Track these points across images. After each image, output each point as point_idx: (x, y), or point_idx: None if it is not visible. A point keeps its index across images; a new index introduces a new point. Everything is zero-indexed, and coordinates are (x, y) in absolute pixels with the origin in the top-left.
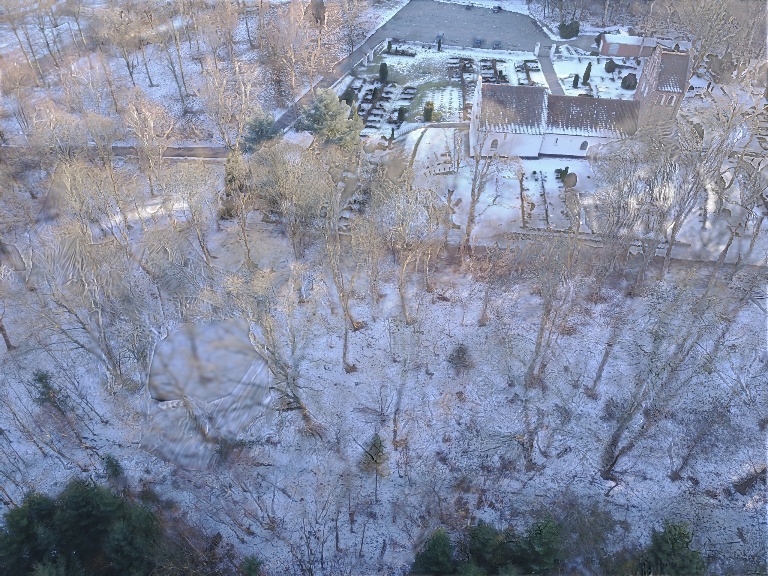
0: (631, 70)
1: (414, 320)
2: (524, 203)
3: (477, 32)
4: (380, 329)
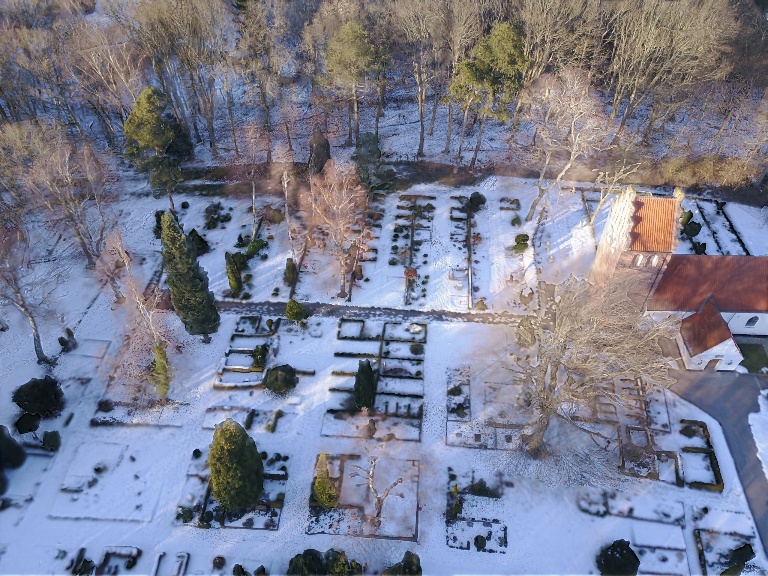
0: None
1: (765, 142)
2: (730, 226)
3: None
4: None
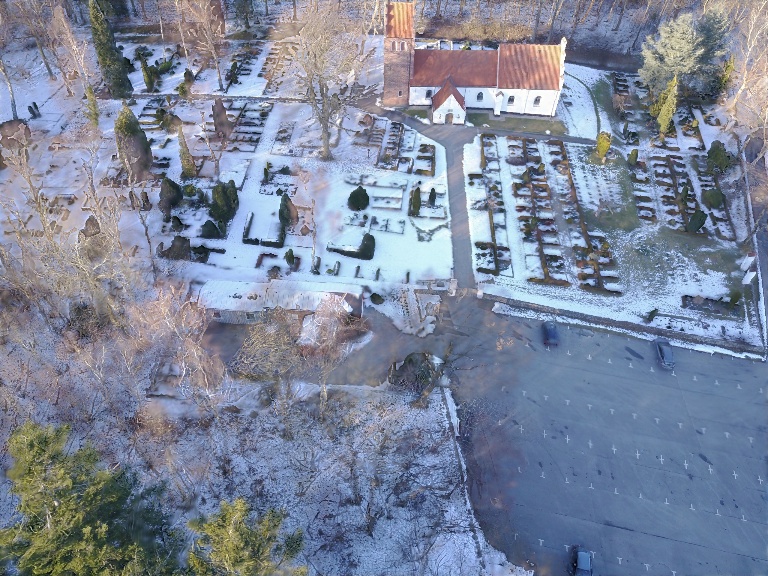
0: (337, 244)
1: None
2: None
3: (600, 402)
4: (568, 20)
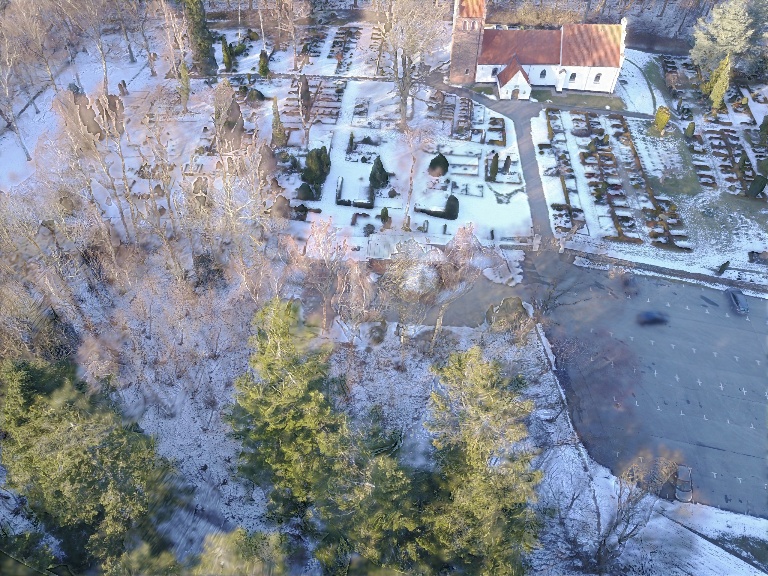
0: (423, 205)
1: None
2: None
3: (682, 342)
4: None
